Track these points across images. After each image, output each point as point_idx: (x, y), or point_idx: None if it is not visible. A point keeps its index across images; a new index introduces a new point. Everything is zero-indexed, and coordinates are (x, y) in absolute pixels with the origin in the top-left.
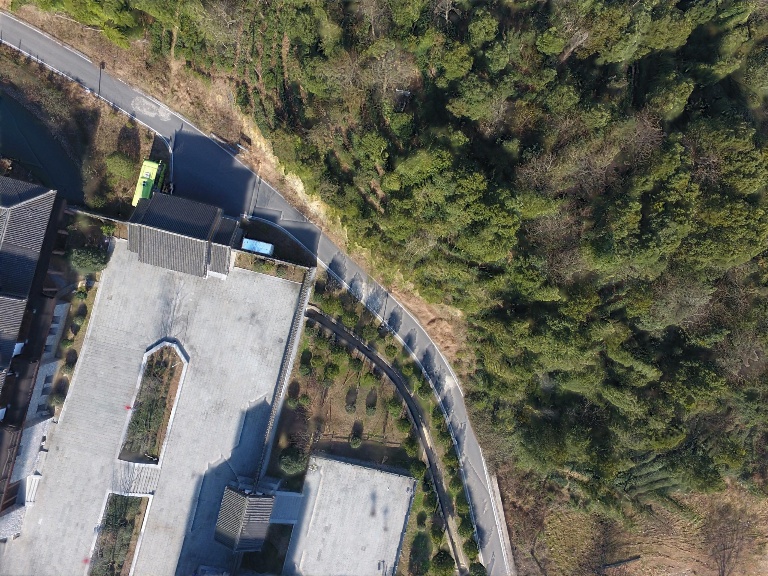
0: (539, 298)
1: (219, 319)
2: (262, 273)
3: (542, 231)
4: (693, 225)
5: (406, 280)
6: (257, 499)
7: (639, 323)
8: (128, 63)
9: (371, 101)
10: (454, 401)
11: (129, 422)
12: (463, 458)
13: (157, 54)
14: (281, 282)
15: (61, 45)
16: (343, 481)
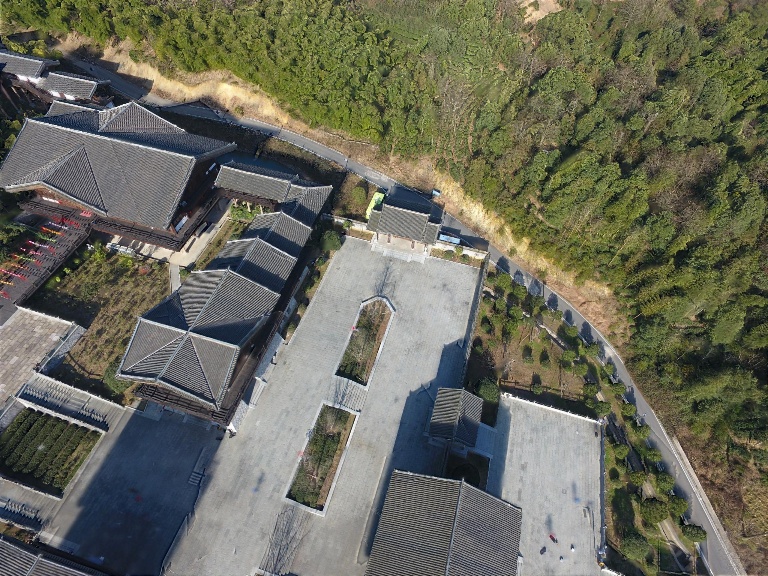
0: (674, 247)
1: (419, 286)
2: (450, 261)
3: (663, 204)
4: (765, 202)
5: (564, 258)
6: (470, 395)
7: (756, 281)
8: (365, 156)
9: (529, 156)
10: (617, 367)
11: (345, 349)
12: (639, 418)
13: (383, 153)
14: (464, 267)
15: (327, 147)
16: (532, 421)
